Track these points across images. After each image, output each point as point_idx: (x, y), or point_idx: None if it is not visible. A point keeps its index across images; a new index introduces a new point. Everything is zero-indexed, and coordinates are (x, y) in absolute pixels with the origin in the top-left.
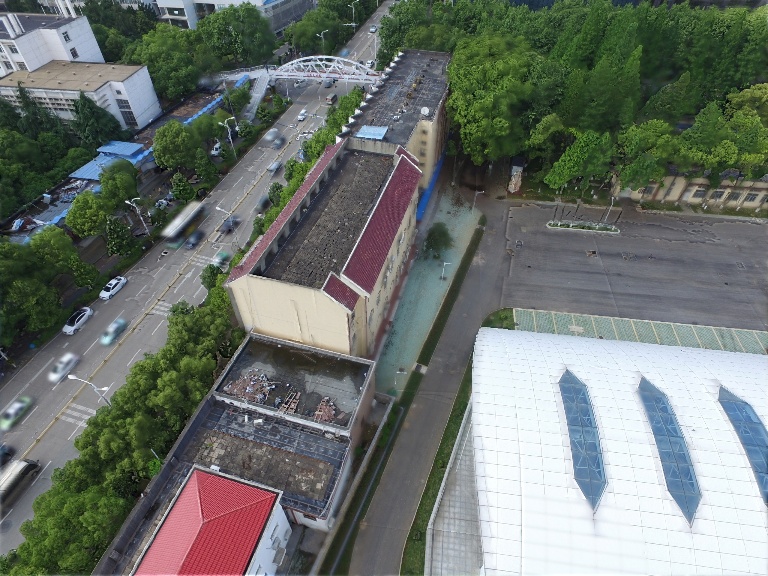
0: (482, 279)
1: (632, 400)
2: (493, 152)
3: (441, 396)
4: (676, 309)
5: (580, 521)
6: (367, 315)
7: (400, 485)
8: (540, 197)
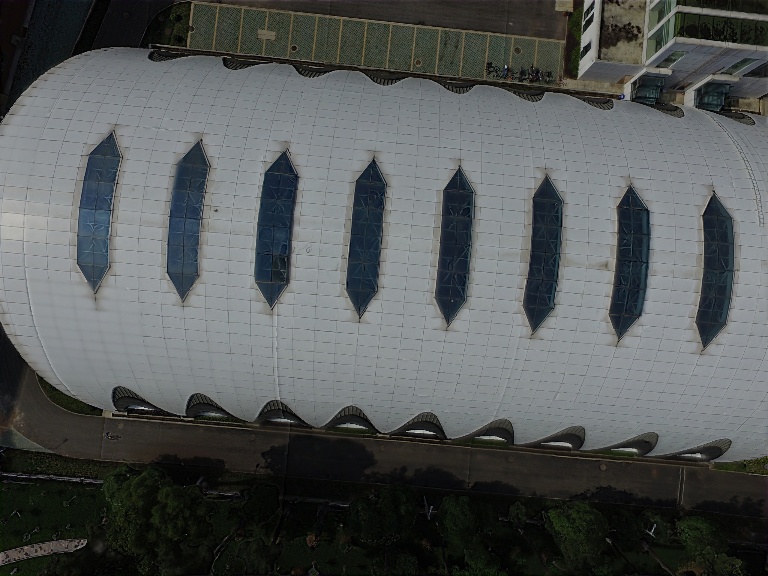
0: None
1: (166, 175)
2: None
3: None
4: None
5: (82, 300)
6: None
7: None
8: None
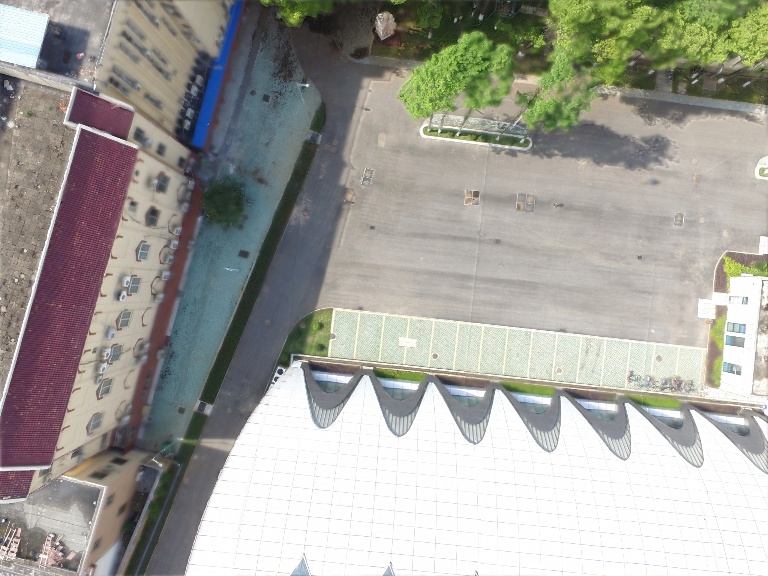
0: (299, 254)
1: None
2: (314, 11)
3: (226, 444)
4: (549, 306)
5: None
6: (75, 447)
7: (178, 544)
8: (427, 54)
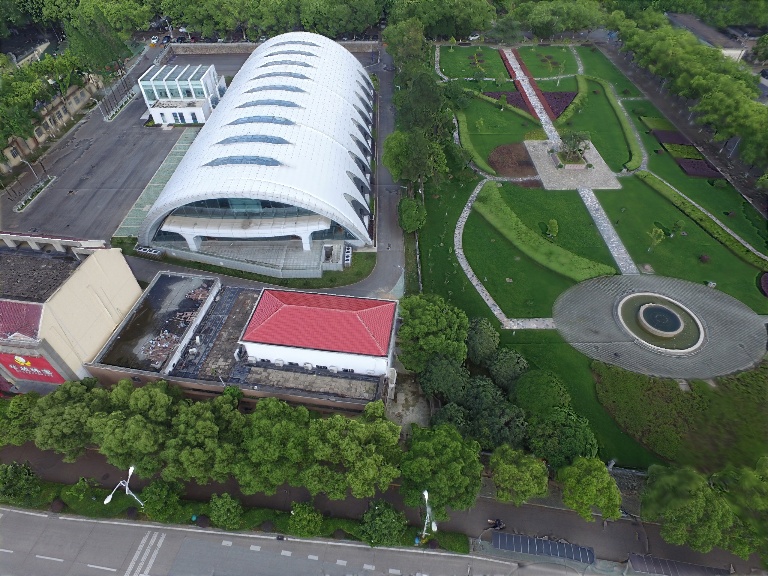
0: None
1: (229, 146)
2: None
3: None
4: (147, 166)
5: (289, 170)
6: None
7: None
8: None
